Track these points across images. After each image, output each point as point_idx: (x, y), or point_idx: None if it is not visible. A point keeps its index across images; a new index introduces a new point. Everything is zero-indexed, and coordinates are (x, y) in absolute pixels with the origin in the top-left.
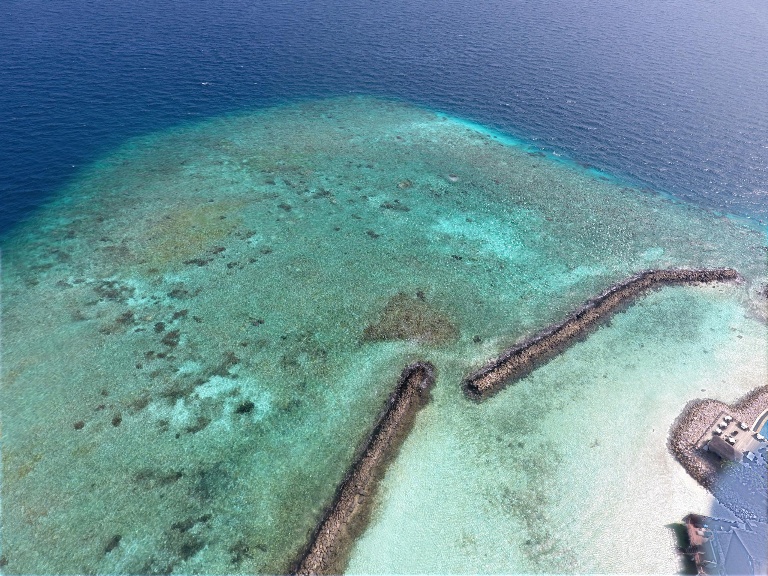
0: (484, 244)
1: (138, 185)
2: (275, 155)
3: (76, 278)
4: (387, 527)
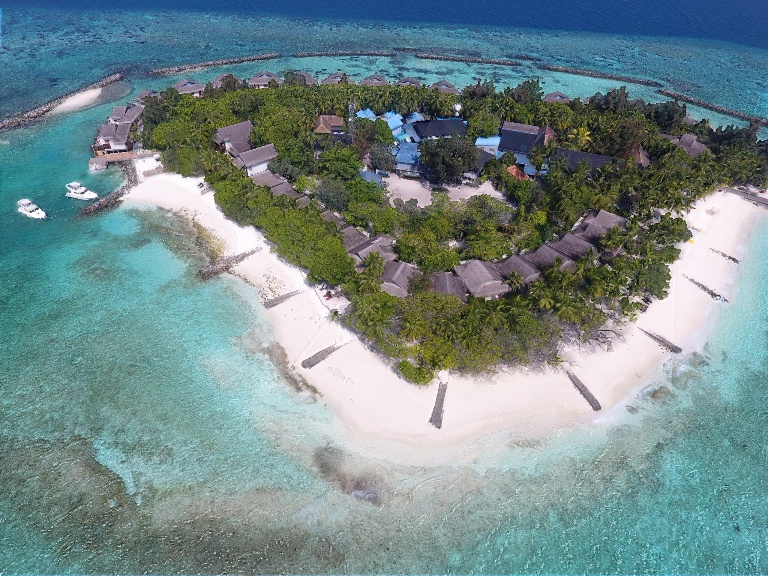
0: (764, 101)
1: (687, 44)
2: (759, 62)
3: (627, 43)
4: (596, 79)
